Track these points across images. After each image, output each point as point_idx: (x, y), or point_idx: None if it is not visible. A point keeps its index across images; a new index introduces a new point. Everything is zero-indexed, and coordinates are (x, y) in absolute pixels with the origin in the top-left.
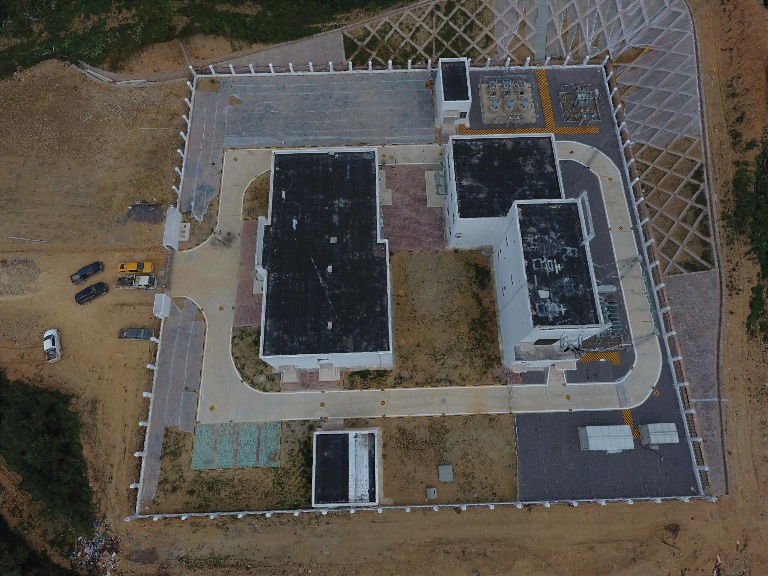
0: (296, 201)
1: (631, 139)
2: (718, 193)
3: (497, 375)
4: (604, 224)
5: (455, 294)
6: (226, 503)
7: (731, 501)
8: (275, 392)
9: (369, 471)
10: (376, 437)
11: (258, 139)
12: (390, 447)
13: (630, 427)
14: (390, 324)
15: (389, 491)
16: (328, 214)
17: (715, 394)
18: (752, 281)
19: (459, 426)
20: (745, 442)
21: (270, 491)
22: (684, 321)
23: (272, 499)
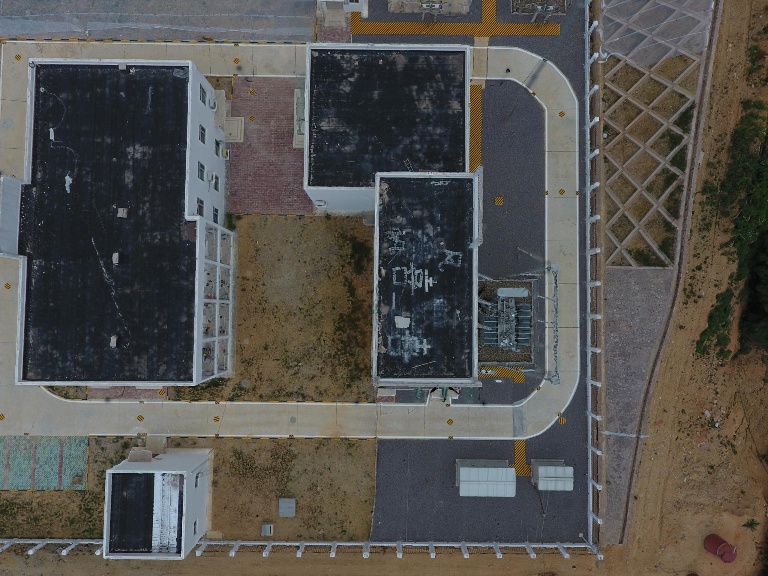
0: (70, 146)
1: (604, 49)
2: (706, 151)
3: (364, 390)
4: (540, 185)
5: (321, 279)
6: (24, 529)
7: (624, 551)
8: (80, 400)
9: (178, 516)
10: (185, 480)
11: (50, 24)
12: (222, 473)
13: (520, 463)
14: (195, 345)
15: (218, 524)
16: (117, 170)
17: (634, 429)
18: (720, 285)
19: (309, 451)
20: (658, 486)
21: (76, 518)
22: (618, 331)
23: (78, 526)
